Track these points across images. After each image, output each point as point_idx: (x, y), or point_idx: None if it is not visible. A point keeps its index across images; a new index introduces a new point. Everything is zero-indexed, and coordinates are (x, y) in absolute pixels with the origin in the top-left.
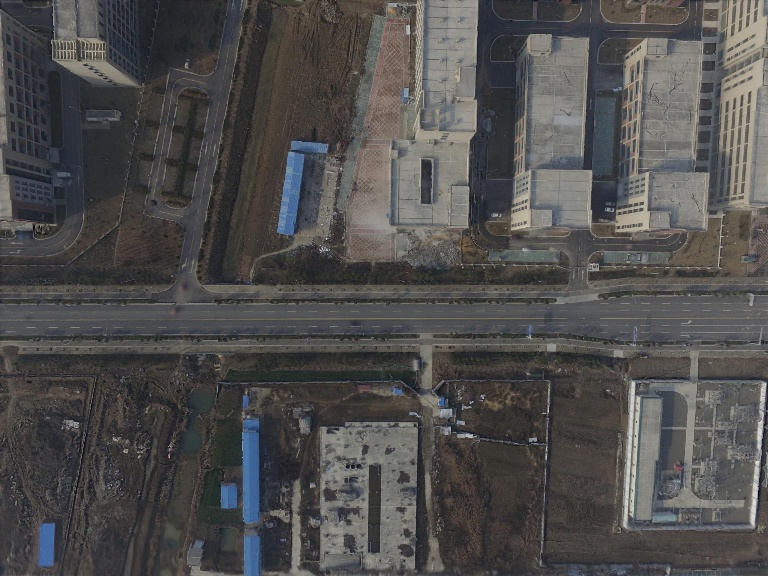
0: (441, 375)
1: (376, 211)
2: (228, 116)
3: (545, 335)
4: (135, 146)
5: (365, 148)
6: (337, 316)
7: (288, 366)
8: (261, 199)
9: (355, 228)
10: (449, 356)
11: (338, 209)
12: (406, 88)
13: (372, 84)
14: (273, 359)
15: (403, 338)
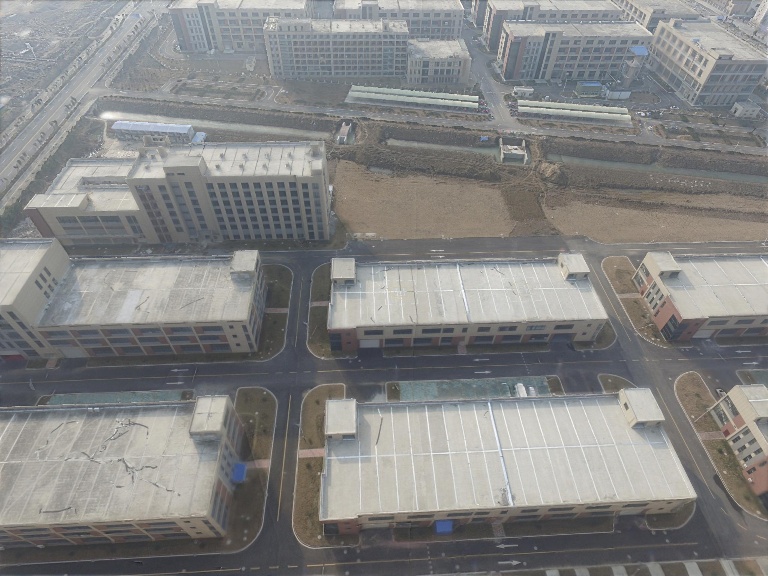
0: None
1: None
2: (239, 108)
3: None
4: None
5: None
6: (14, 162)
7: None
8: None
9: None
10: None
11: None
12: None
13: None
14: None
15: None
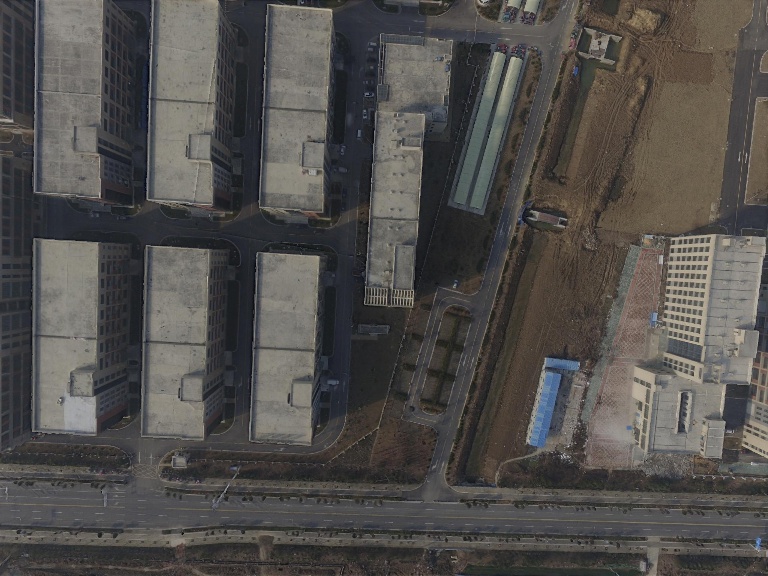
0: (664, 575)
1: (617, 423)
2: (488, 332)
3: (765, 542)
4: (400, 357)
5: (612, 365)
6: (573, 518)
7: (528, 566)
8: (511, 408)
9: (596, 438)
10: (674, 558)
11: (582, 420)
12: (655, 313)
13: (623, 307)
14: (511, 557)
15: (632, 540)
